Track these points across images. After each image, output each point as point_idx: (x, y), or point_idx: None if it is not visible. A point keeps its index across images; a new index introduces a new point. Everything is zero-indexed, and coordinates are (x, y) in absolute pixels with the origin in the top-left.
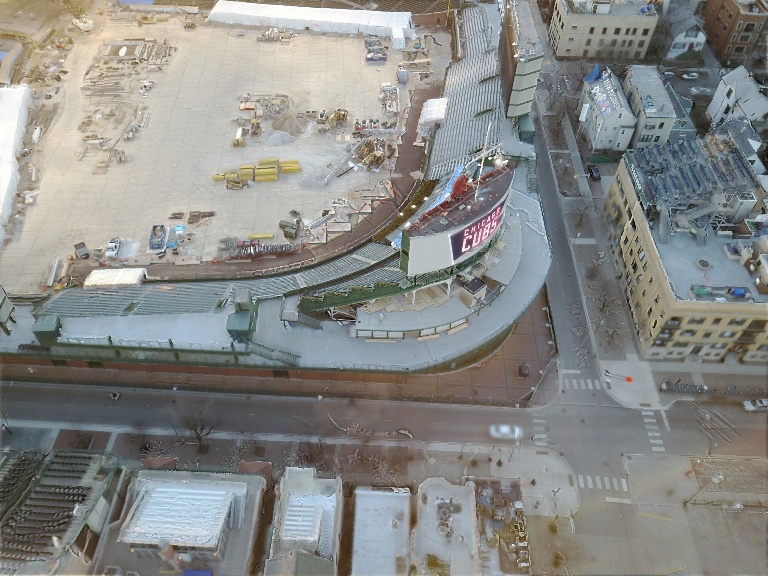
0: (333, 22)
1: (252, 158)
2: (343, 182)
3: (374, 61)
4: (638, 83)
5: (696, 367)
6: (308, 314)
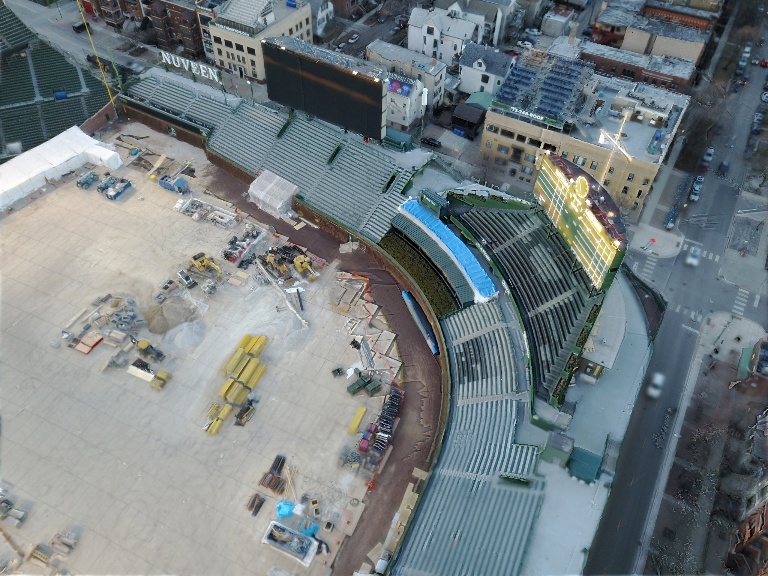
0: (8, 190)
1: (201, 378)
2: (314, 309)
3: (121, 194)
4: (397, 56)
5: (652, 203)
6: (562, 404)
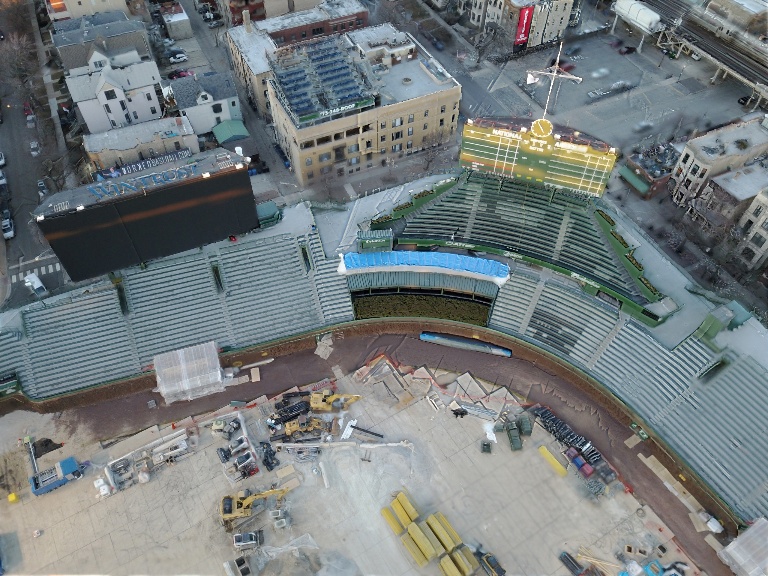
0: None
1: None
2: (389, 425)
3: (1, 559)
4: (138, 139)
5: None
6: None
